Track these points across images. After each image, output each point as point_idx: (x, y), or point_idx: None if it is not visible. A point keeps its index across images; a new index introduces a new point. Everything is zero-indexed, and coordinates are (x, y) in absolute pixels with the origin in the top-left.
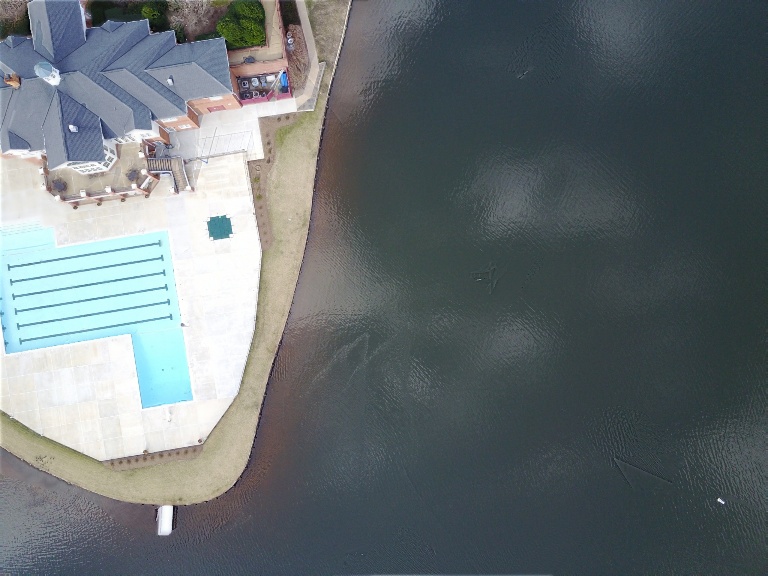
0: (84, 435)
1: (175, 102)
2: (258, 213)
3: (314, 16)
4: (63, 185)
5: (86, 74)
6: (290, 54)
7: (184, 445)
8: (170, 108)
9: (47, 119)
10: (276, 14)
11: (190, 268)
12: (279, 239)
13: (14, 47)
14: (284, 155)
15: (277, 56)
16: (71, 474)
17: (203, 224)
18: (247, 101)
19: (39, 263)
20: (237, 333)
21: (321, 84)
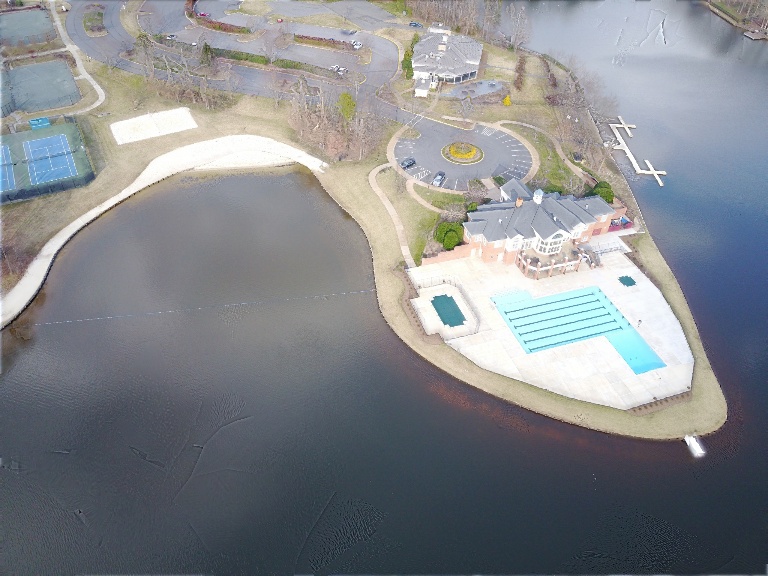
0: (604, 395)
1: (591, 215)
2: (645, 273)
3: None
4: (537, 260)
5: (553, 199)
6: None
7: (678, 392)
8: (590, 218)
9: (535, 220)
10: None
11: (621, 301)
12: (664, 284)
13: None
14: (642, 249)
15: None
16: (606, 424)
17: (616, 280)
18: (611, 228)
19: (524, 309)
20: (671, 328)
21: None
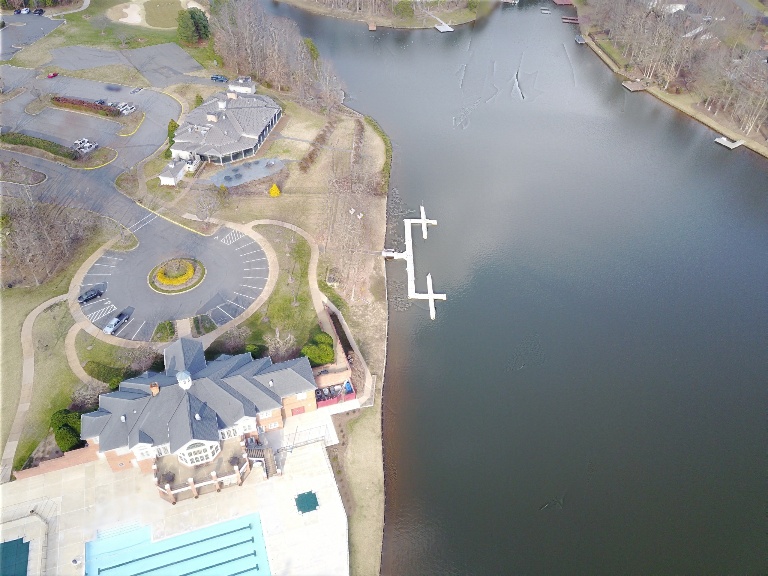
0: None
1: (274, 398)
2: (339, 485)
3: (363, 349)
4: (172, 477)
5: (211, 379)
6: (352, 367)
7: None
8: (270, 402)
9: (174, 416)
10: (339, 346)
11: (281, 542)
12: (361, 505)
13: (149, 377)
14: (355, 439)
15: (343, 369)
16: None
17: (291, 501)
18: (322, 403)
19: (131, 562)
20: None
21: (375, 389)
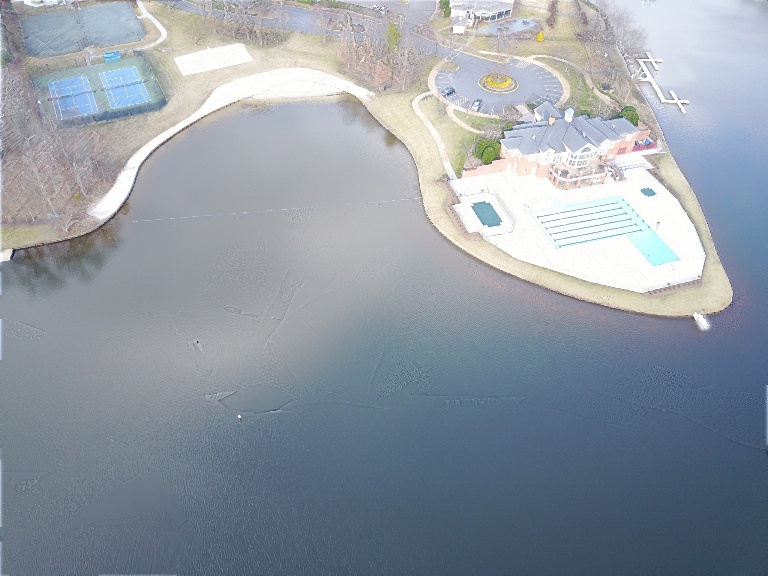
0: (624, 282)
1: None
2: (665, 186)
3: None
4: (567, 172)
5: None
6: (650, 129)
7: (690, 280)
8: (616, 136)
9: (565, 137)
10: None
11: (642, 208)
12: (682, 195)
13: None
14: (663, 166)
15: None
16: (624, 304)
17: (638, 192)
18: (635, 148)
19: (554, 214)
20: (686, 231)
21: None
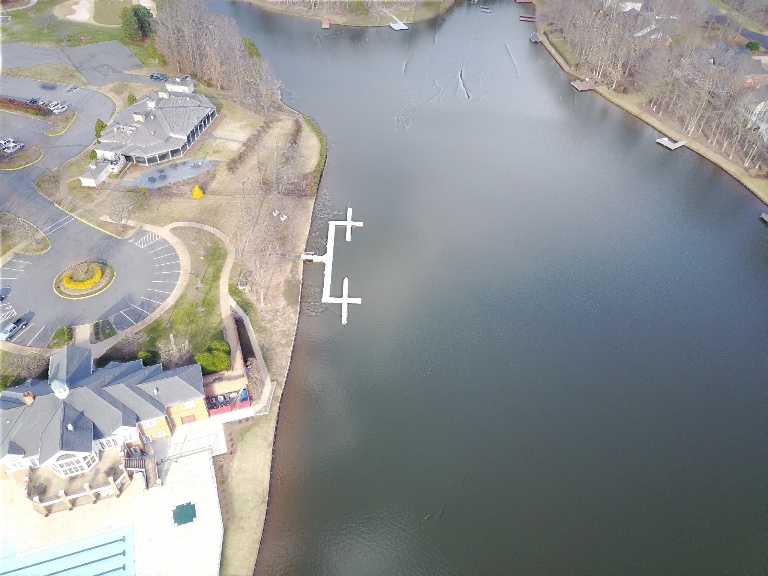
0: None
1: (158, 406)
2: (221, 496)
3: (266, 355)
4: (43, 489)
5: (90, 388)
6: (249, 374)
7: None
8: (153, 411)
9: (48, 426)
10: (238, 352)
11: (152, 556)
12: (240, 516)
13: (31, 386)
14: (244, 448)
15: (239, 376)
16: None
17: (169, 513)
18: (214, 411)
19: None
20: None
21: (273, 396)
